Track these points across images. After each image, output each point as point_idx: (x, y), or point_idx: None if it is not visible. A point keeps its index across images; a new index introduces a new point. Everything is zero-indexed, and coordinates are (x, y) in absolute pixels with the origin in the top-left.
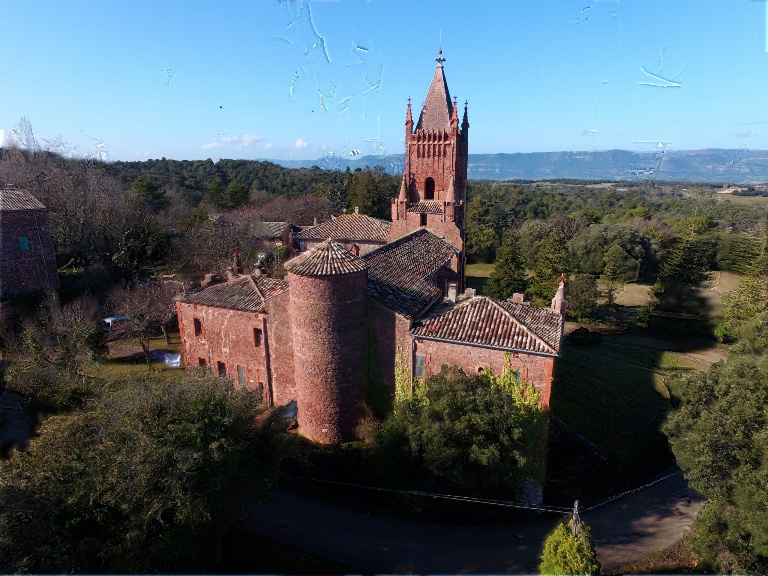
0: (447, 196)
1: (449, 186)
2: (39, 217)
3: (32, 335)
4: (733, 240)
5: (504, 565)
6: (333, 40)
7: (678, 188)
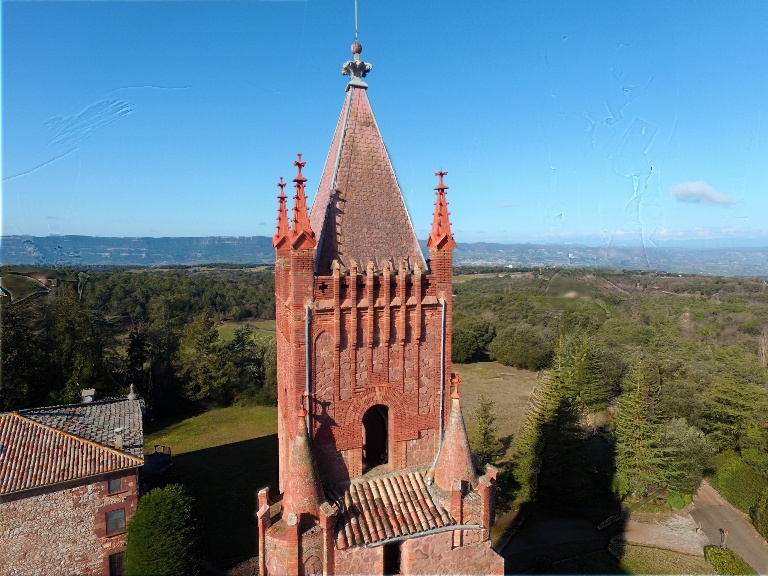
0: (451, 461)
1: (452, 429)
2: None
3: None
4: (585, 367)
5: None
6: None
7: (550, 316)
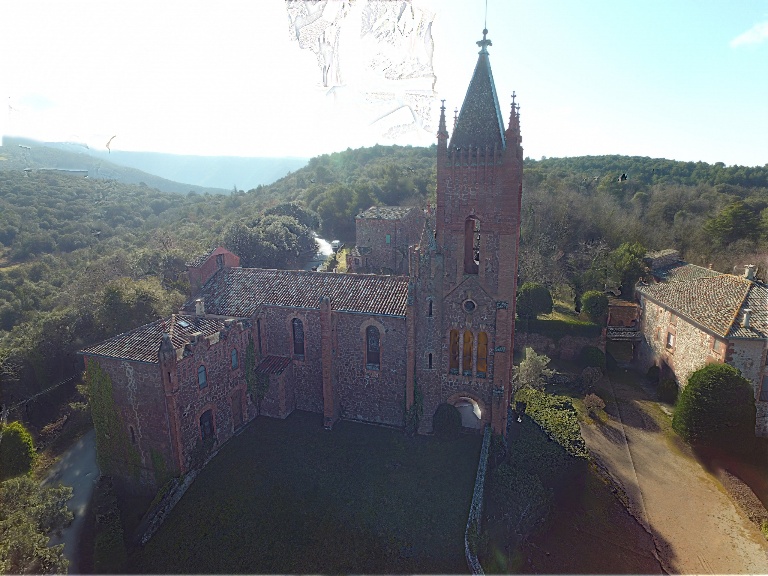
0: None
1: None
2: (397, 224)
3: None
4: None
5: (72, 462)
6: (445, 61)
7: None
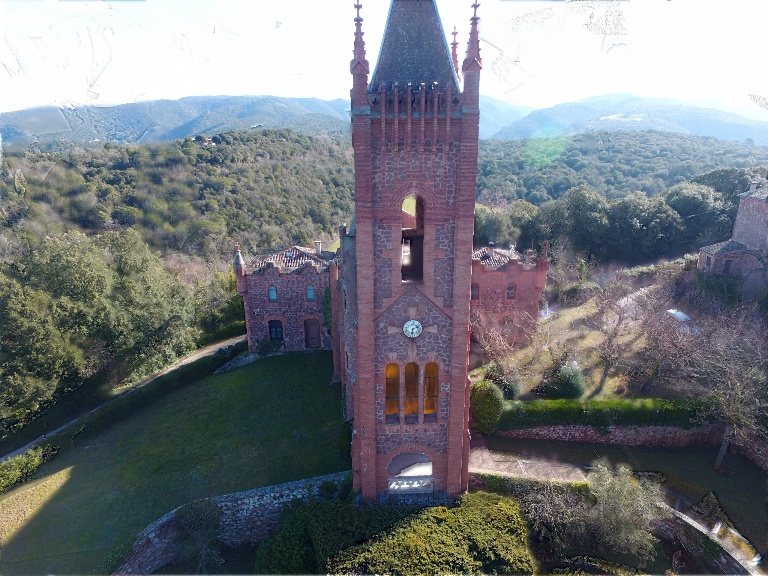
0: None
1: None
2: None
3: (581, 263)
4: None
5: None
6: None
7: None
